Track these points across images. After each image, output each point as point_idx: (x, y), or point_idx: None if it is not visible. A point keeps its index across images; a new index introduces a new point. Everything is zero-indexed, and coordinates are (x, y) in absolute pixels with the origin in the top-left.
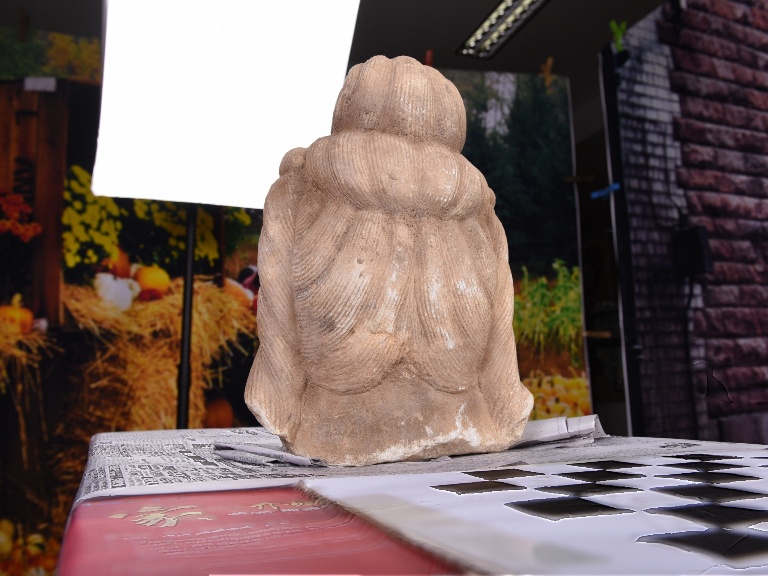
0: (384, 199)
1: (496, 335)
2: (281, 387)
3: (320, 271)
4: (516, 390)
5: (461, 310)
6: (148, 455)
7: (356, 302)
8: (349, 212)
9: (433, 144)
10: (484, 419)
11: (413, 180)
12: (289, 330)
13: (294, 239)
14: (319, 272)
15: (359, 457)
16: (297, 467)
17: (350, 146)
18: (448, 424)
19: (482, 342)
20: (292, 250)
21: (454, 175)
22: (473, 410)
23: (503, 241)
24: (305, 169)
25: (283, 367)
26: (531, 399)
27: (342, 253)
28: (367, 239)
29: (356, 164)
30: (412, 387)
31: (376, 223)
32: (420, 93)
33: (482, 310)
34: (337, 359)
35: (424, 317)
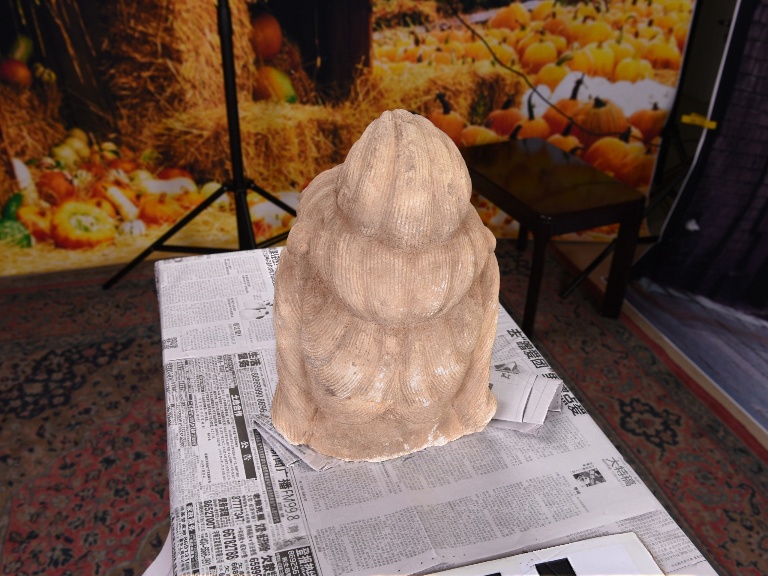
0: (376, 318)
1: (472, 373)
2: (298, 417)
3: (323, 357)
4: (482, 409)
5: (438, 383)
6: (208, 425)
7: (351, 386)
8: (347, 319)
9: (429, 248)
10: (453, 426)
11: (403, 304)
12: (302, 382)
13: (302, 319)
14: (322, 357)
15: (355, 459)
16: (310, 471)
17: (348, 261)
18: (422, 441)
19: (456, 389)
20: (301, 328)
21: (443, 288)
22: (444, 425)
23: (494, 292)
24: (310, 257)
25: (298, 406)
26: (494, 411)
27: (340, 353)
28: (360, 349)
29: (352, 285)
30: (395, 424)
31: (369, 335)
32: (418, 213)
33: (458, 375)
34: (338, 409)
35: (406, 393)
